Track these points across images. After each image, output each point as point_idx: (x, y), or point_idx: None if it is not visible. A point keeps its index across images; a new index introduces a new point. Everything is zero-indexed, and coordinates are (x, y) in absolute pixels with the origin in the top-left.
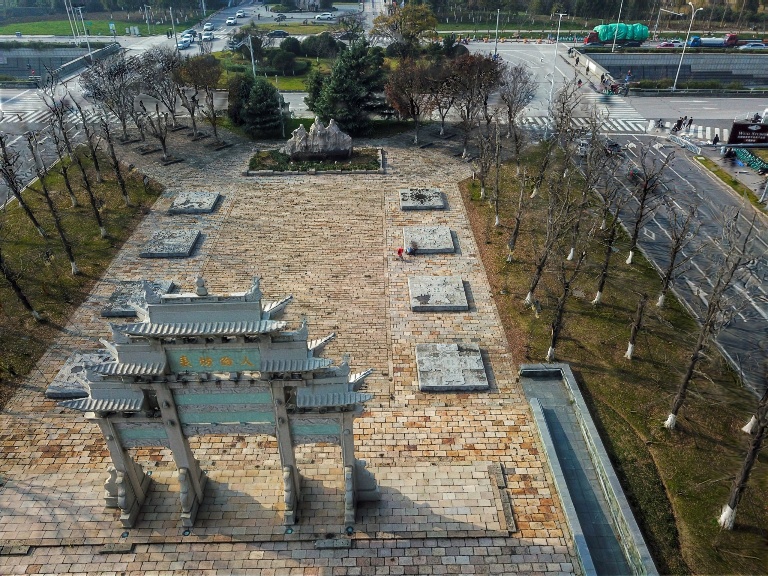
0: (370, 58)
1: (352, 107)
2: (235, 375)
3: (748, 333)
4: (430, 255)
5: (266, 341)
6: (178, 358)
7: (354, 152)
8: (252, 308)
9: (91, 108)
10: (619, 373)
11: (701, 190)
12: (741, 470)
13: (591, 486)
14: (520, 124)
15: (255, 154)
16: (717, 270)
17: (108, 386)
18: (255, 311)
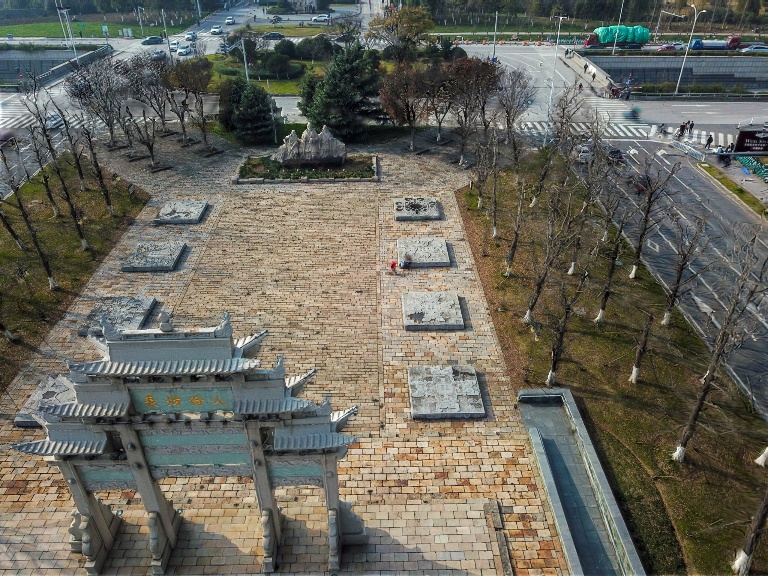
0: (365, 62)
1: (346, 112)
2: (206, 415)
3: (758, 354)
4: (425, 269)
5: (239, 380)
6: (143, 397)
7: (348, 159)
8: (222, 345)
9: (79, 113)
10: (623, 399)
11: (706, 199)
12: (757, 514)
13: (594, 526)
14: (519, 129)
15: (246, 161)
16: (724, 285)
17: (67, 427)
18: (226, 348)
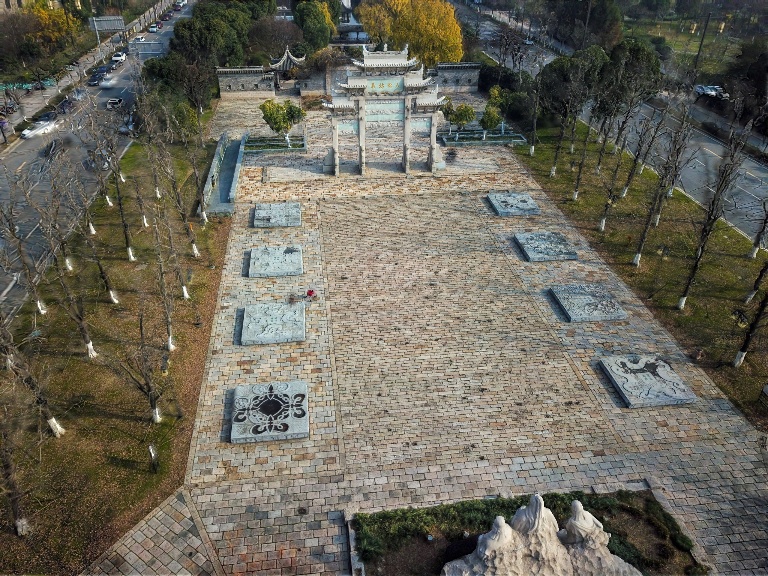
0: None
1: None
2: None
3: None
4: None
5: None
6: None
7: None
8: None
9: None
10: None
11: None
12: None
13: None
14: None
15: None
16: None
17: None
18: None
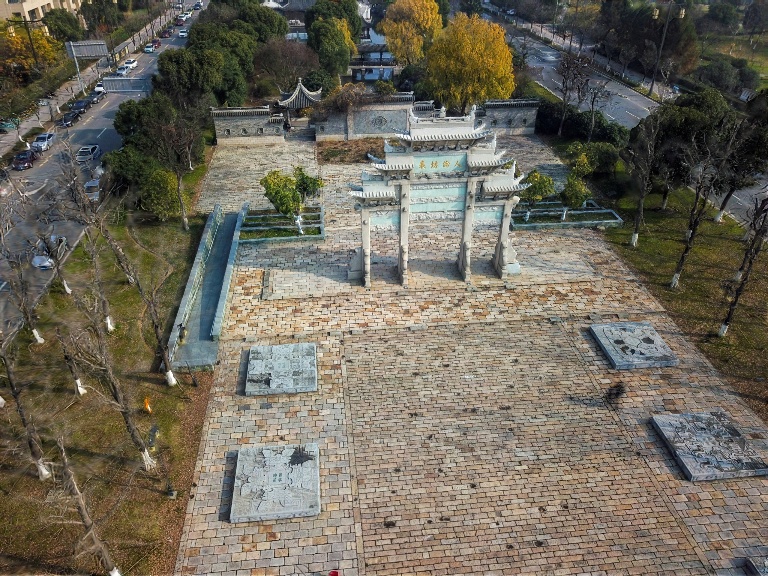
0: None
1: None
2: None
3: None
4: None
5: None
6: None
7: None
8: None
9: None
10: None
11: None
12: None
13: None
14: None
15: None
16: None
17: None
18: None
